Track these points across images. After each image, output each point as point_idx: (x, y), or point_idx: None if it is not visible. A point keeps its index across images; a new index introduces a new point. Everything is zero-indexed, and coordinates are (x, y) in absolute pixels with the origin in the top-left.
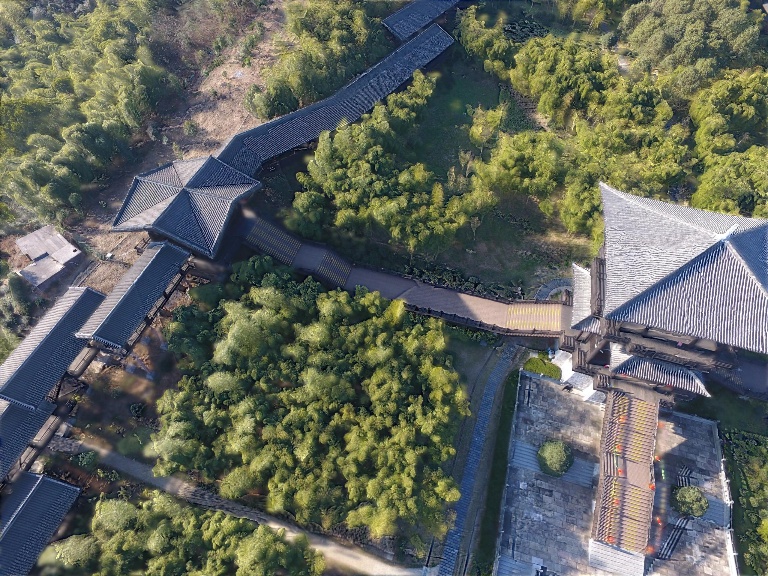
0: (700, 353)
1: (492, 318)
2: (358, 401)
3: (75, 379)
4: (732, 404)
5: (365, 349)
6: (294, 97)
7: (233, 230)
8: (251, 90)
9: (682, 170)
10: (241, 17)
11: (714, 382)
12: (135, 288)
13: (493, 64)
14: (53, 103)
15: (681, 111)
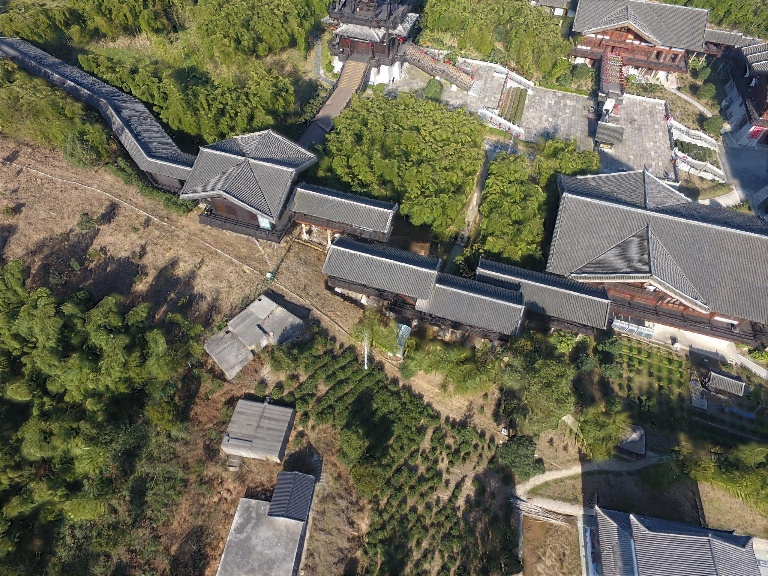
0: (401, 5)
1: (348, 94)
2: None
3: None
4: None
5: None
6: None
7: None
8: (76, 140)
9: None
10: None
11: None
12: None
13: (76, 30)
14: None
15: None
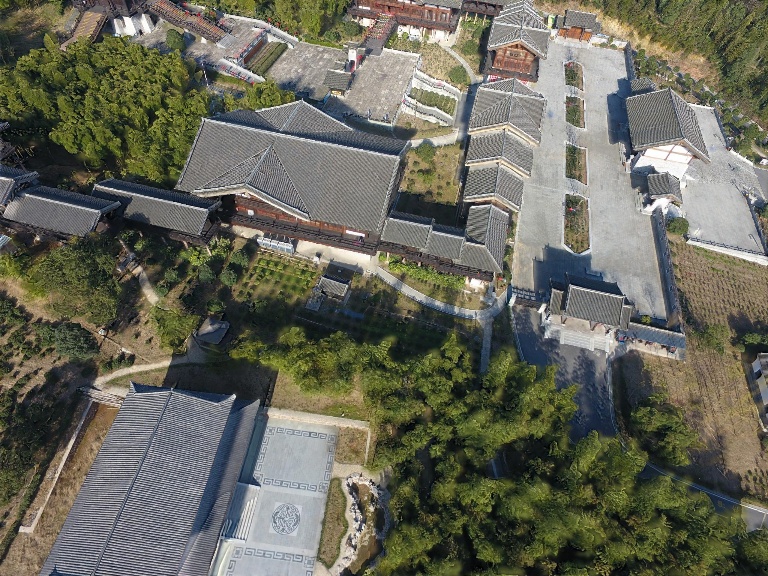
0: None
1: None
2: None
3: None
4: None
5: (74, 61)
6: None
7: None
8: None
9: None
10: None
11: None
12: None
13: None
14: None
15: None
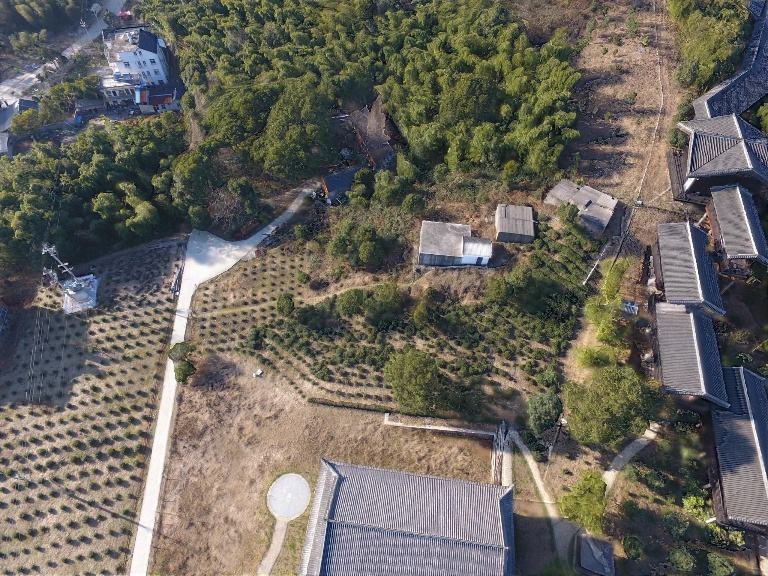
0: None
1: None
2: None
3: None
4: None
5: None
6: None
7: None
8: (695, 62)
9: None
10: (592, 2)
11: None
12: (748, 220)
13: None
14: None
15: None
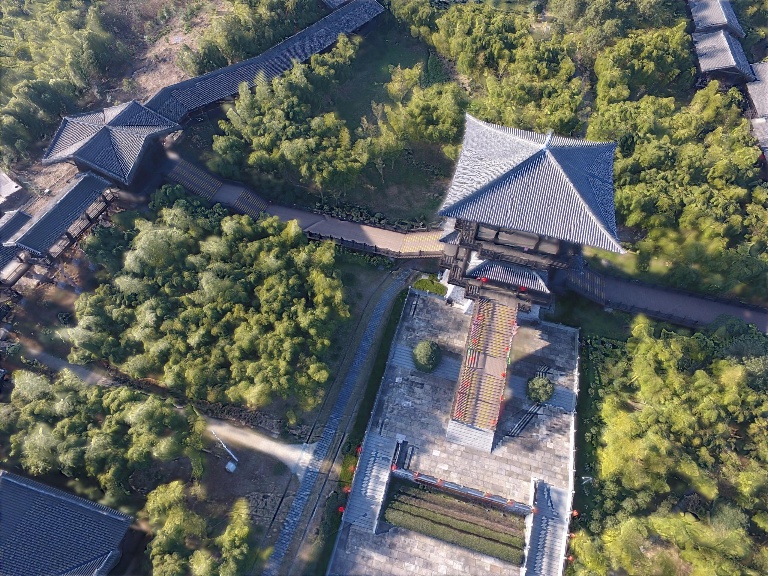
0: (543, 256)
1: (388, 245)
2: (250, 304)
3: (9, 289)
4: (598, 316)
5: (260, 262)
6: (223, 56)
7: (156, 168)
8: (181, 49)
9: (574, 117)
10: None
11: (582, 297)
12: (57, 208)
13: (419, 29)
14: (10, 67)
15: (592, 70)
